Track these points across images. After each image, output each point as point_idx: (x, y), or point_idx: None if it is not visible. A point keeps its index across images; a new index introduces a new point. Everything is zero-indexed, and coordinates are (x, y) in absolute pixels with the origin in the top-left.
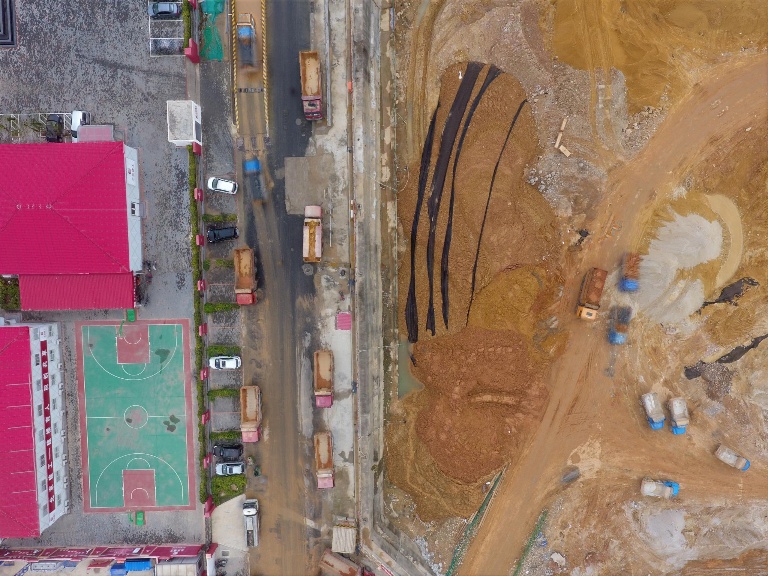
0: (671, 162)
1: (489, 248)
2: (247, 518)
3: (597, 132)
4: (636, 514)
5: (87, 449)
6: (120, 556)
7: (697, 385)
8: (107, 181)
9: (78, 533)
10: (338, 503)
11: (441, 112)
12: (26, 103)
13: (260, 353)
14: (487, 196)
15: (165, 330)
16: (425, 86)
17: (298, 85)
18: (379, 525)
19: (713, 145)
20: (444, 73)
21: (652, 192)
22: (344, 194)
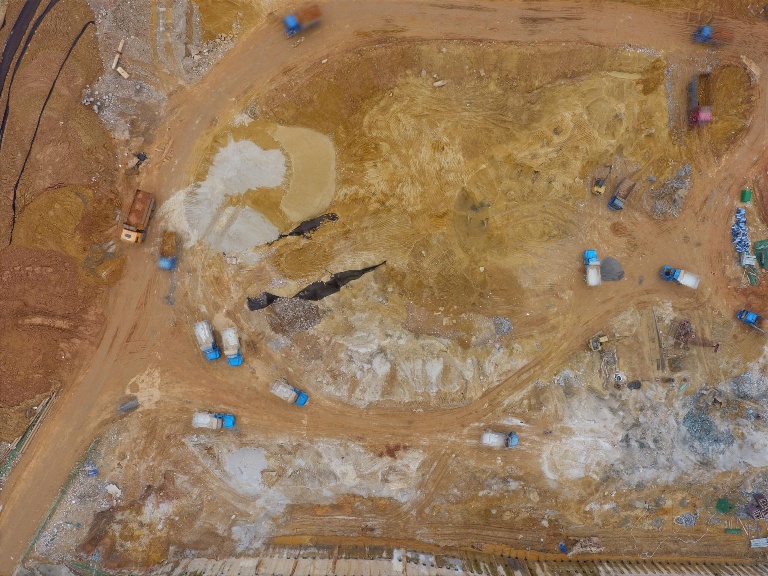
0: (235, 89)
1: (35, 166)
2: None
3: (158, 55)
4: (212, 450)
5: None
6: None
7: (259, 317)
8: None
9: None
10: None
11: (4, 30)
12: None
13: None
14: (38, 114)
15: None
16: None
17: None
18: None
19: (287, 75)
20: None
21: (213, 118)
22: None
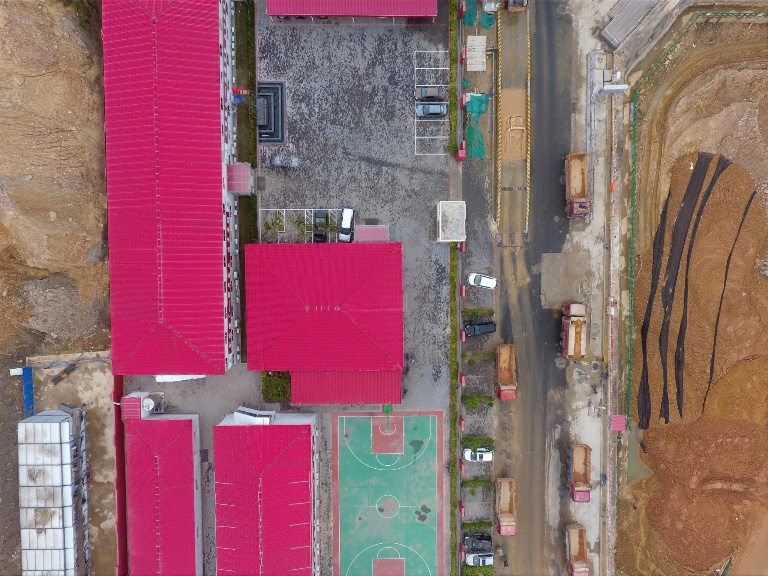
0: None
1: (726, 339)
2: None
3: None
4: None
5: (339, 538)
6: None
7: None
8: (387, 282)
9: None
10: None
11: (673, 202)
12: (292, 199)
13: (510, 444)
14: (722, 287)
15: (420, 421)
16: (659, 177)
17: (557, 183)
18: None
19: None
20: (675, 163)
21: None
22: (599, 289)
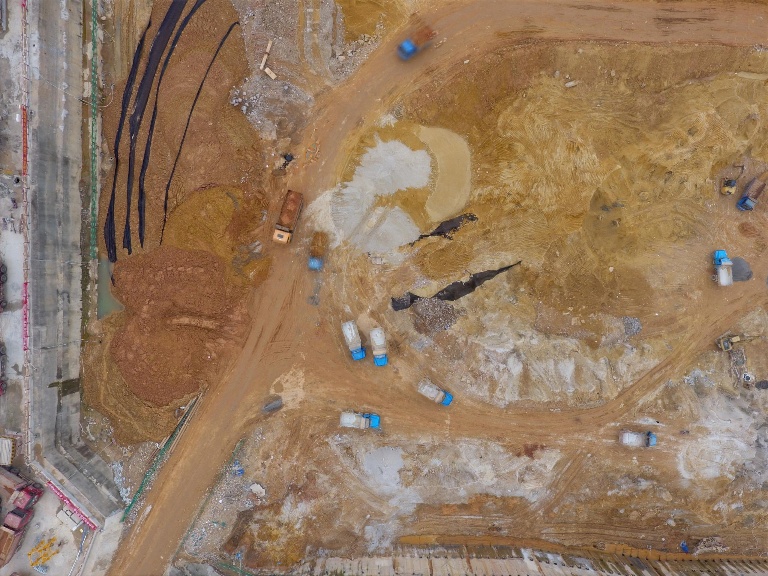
0: (381, 90)
1: (185, 167)
2: None
3: (305, 56)
4: (350, 450)
5: None
6: None
7: (403, 317)
8: None
9: None
10: (11, 417)
11: (150, 31)
12: None
13: None
14: (188, 115)
15: None
16: (133, 3)
17: None
18: (63, 445)
19: (429, 76)
20: None
21: (359, 119)
22: (19, 100)
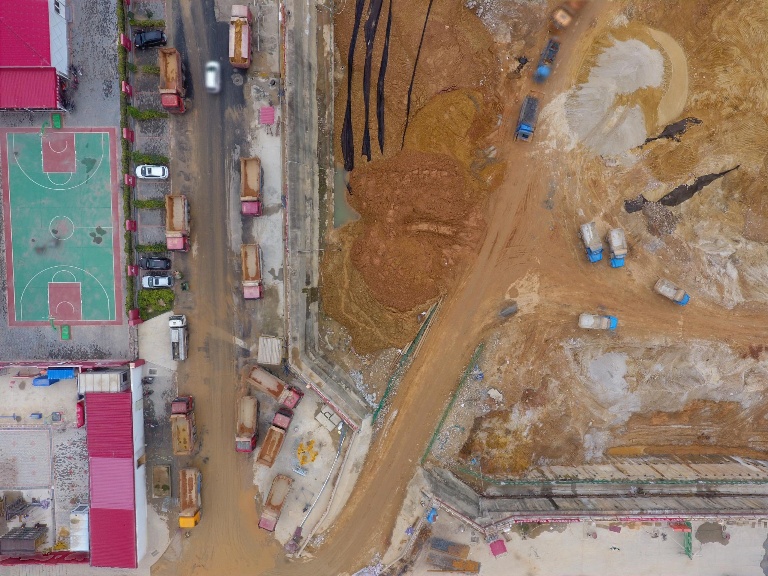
0: None
1: (425, 70)
2: (173, 329)
3: None
4: (577, 357)
5: (12, 260)
6: (43, 365)
7: (637, 219)
8: None
9: (3, 347)
10: (267, 322)
11: None
12: None
13: (188, 165)
14: (424, 19)
15: (91, 138)
16: None
17: None
18: (311, 351)
19: None
20: None
21: (592, 19)
22: (274, 1)
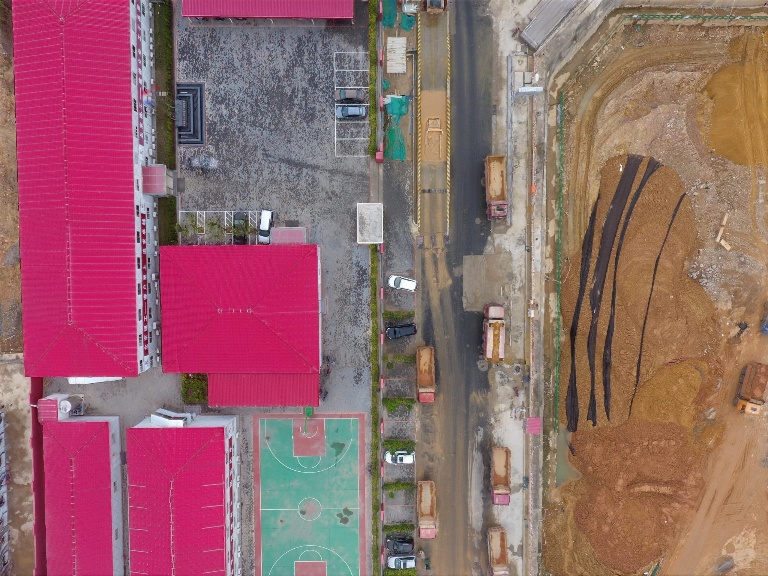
0: None
1: (652, 341)
2: None
3: (757, 226)
4: None
5: (260, 540)
6: None
7: None
8: (302, 284)
9: None
10: None
11: (602, 204)
12: (212, 200)
13: (433, 447)
14: (650, 289)
15: (341, 424)
16: (587, 179)
17: (479, 185)
18: None
19: None
20: (604, 165)
21: None
22: (521, 292)
